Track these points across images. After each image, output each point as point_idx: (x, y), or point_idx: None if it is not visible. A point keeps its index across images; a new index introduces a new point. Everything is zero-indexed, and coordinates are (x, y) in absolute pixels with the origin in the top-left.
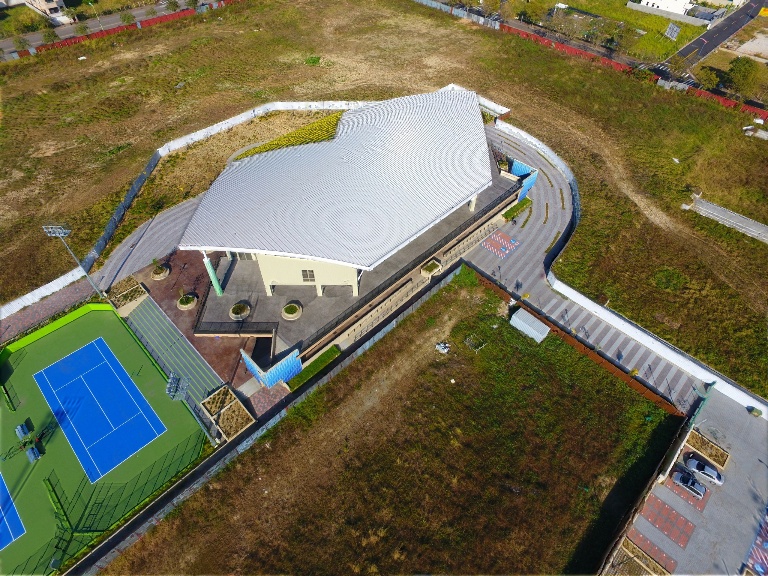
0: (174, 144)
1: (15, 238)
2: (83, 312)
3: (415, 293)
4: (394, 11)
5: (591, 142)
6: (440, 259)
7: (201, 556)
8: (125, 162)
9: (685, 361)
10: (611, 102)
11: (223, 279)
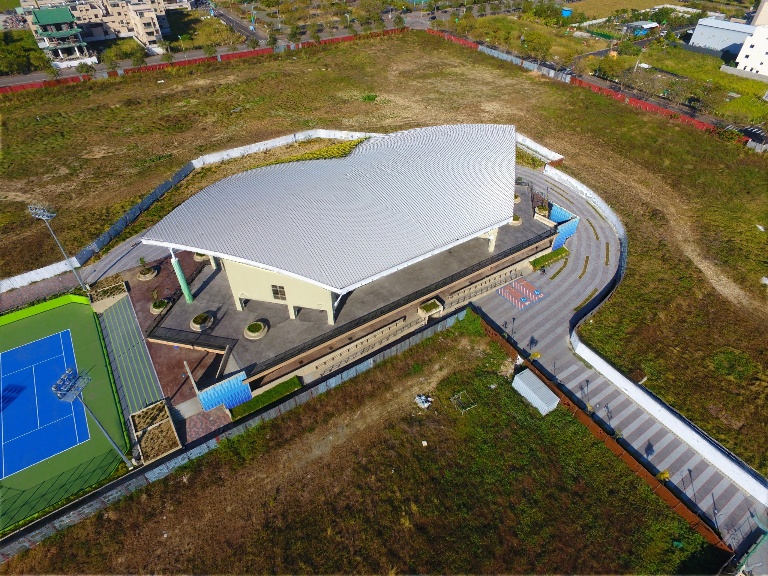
0: (209, 158)
1: (34, 225)
2: (63, 302)
3: (406, 333)
4: (463, 61)
5: (654, 198)
6: (444, 300)
7: None
8: (161, 170)
9: (741, 473)
10: (686, 160)
11: (199, 286)
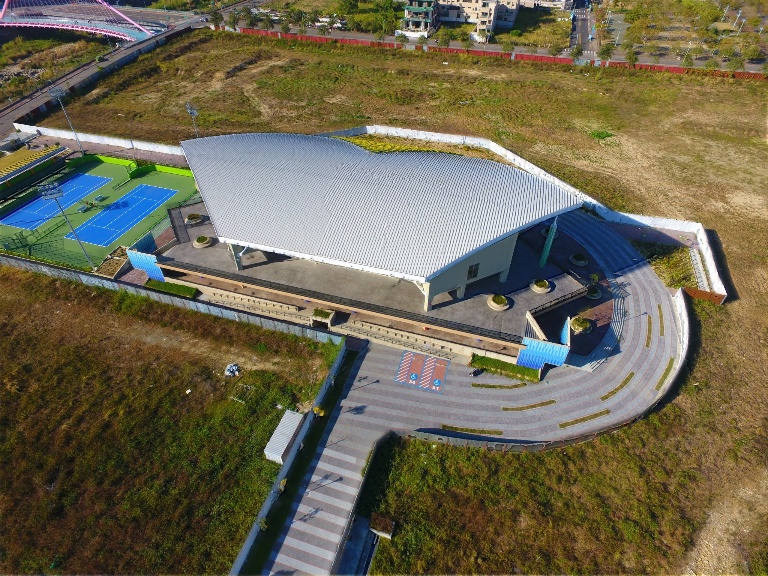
0: (382, 129)
1: (244, 128)
2: None
3: (290, 320)
4: None
5: None
6: (348, 321)
7: (9, 301)
8: (349, 125)
9: None
10: None
11: None
